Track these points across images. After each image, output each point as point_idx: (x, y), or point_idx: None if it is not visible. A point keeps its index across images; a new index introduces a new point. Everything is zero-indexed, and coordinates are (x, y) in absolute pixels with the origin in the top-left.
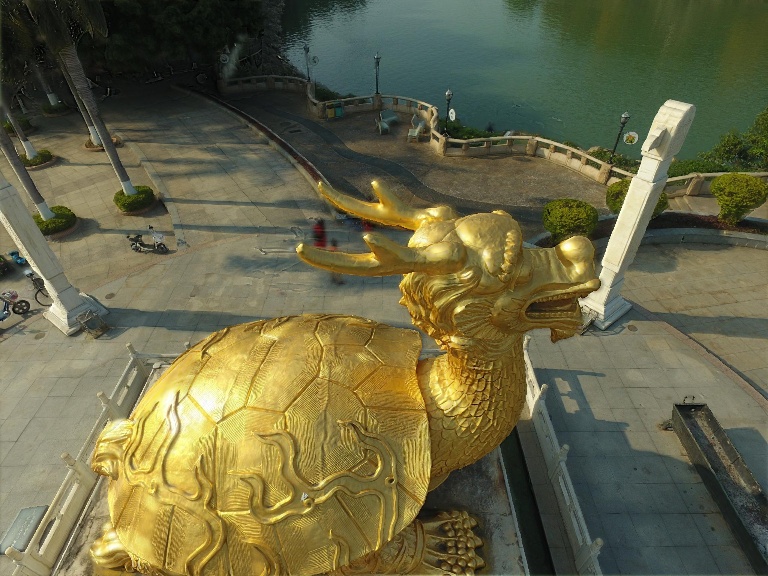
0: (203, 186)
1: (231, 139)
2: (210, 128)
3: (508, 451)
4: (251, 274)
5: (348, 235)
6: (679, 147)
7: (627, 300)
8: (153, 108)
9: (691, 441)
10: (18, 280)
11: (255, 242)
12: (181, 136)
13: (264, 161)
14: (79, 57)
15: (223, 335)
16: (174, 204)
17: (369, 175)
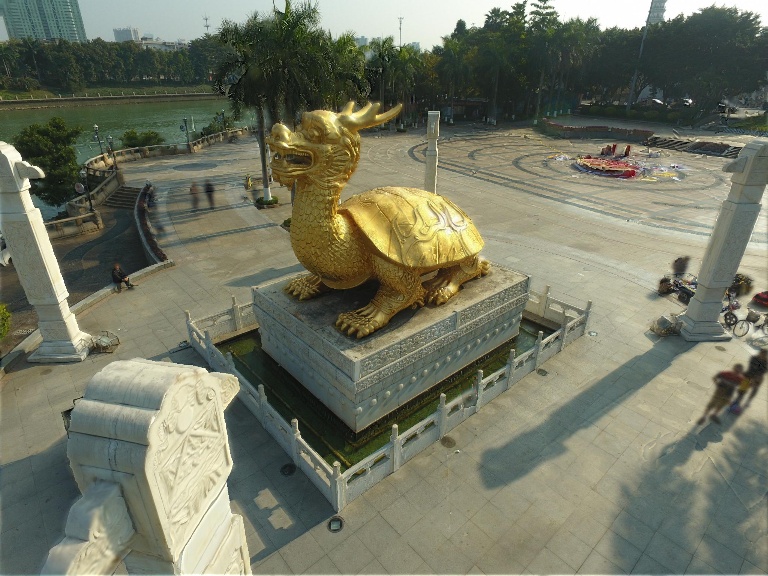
0: None
1: None
2: None
3: (311, 442)
4: (715, 431)
5: None
6: None
7: None
8: None
9: None
10: None
11: None
12: None
13: None
14: None
15: (447, 202)
16: None
17: None
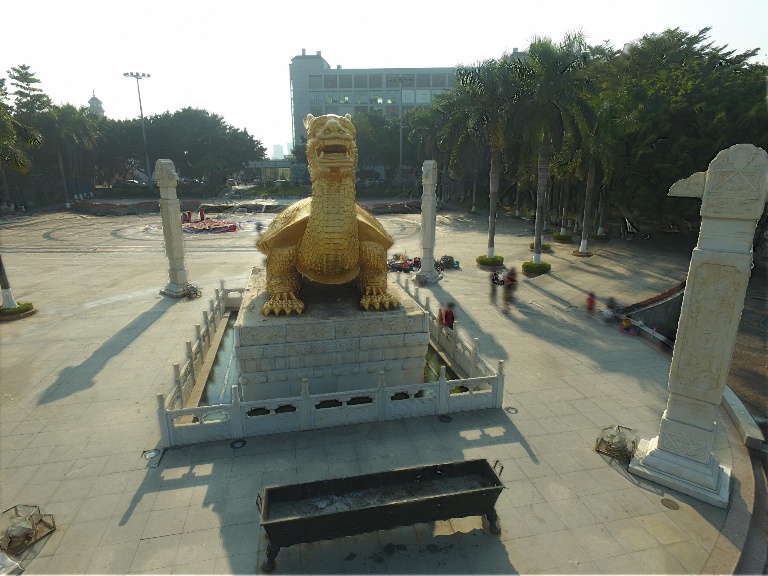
0: (580, 277)
1: (662, 272)
2: (664, 265)
3: None
4: None
5: (597, 323)
6: (755, 209)
7: (745, 507)
8: (654, 250)
9: (443, 476)
10: (444, 270)
11: (539, 299)
12: (632, 261)
13: (652, 285)
14: (622, 203)
15: None
16: (546, 275)
17: (754, 339)
